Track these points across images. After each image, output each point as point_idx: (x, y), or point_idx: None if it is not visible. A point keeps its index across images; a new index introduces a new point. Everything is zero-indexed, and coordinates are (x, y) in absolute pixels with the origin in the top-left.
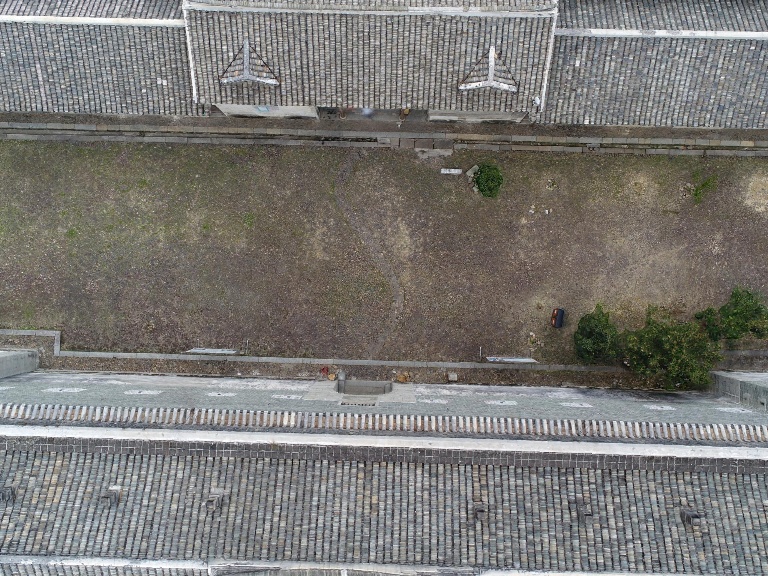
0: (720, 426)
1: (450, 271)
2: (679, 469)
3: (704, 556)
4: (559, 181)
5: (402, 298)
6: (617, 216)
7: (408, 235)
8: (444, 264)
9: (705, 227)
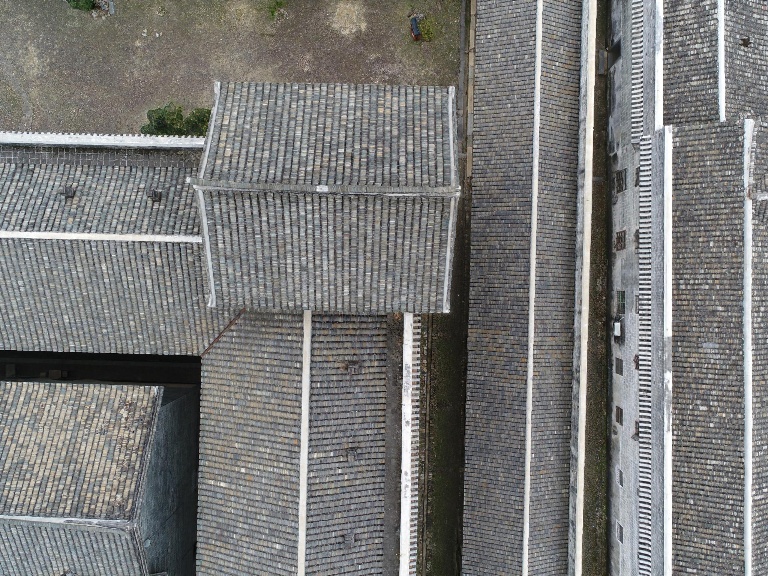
0: (129, 135)
1: (73, 88)
2: (79, 163)
3: (73, 221)
4: (169, 8)
5: (31, 112)
6: (220, 39)
7: (36, 56)
8: (68, 82)
9: (297, 48)
